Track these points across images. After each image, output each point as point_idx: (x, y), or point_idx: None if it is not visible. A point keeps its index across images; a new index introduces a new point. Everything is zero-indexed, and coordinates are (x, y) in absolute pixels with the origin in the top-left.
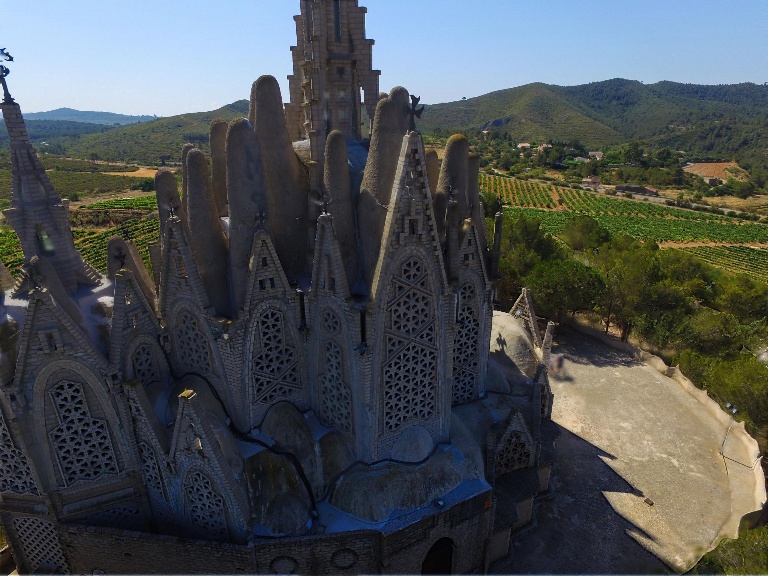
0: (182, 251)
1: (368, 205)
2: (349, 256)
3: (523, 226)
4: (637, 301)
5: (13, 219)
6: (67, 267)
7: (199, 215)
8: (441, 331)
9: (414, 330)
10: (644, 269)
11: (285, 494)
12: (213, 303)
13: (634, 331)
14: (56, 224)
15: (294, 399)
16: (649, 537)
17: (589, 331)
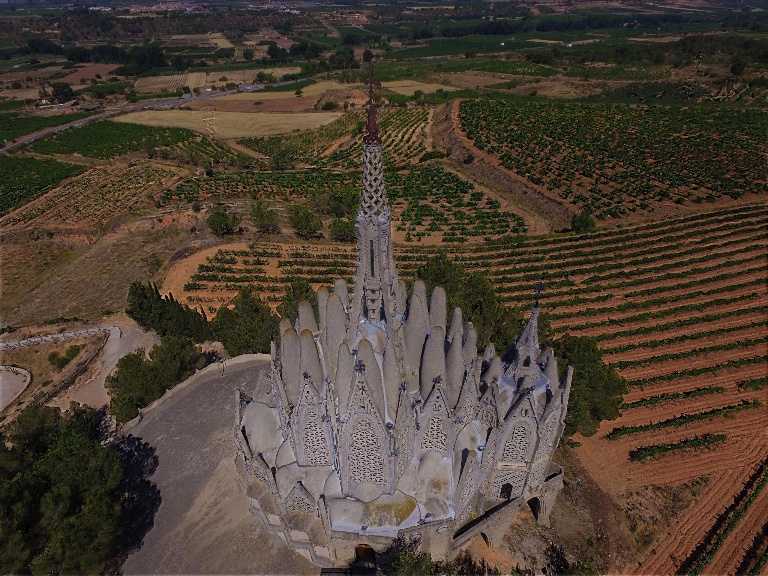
0: None
1: None
2: None
3: None
4: None
5: None
6: None
7: None
8: None
9: None
10: (1, 439)
11: None
12: None
13: None
14: None
15: None
16: None
17: None
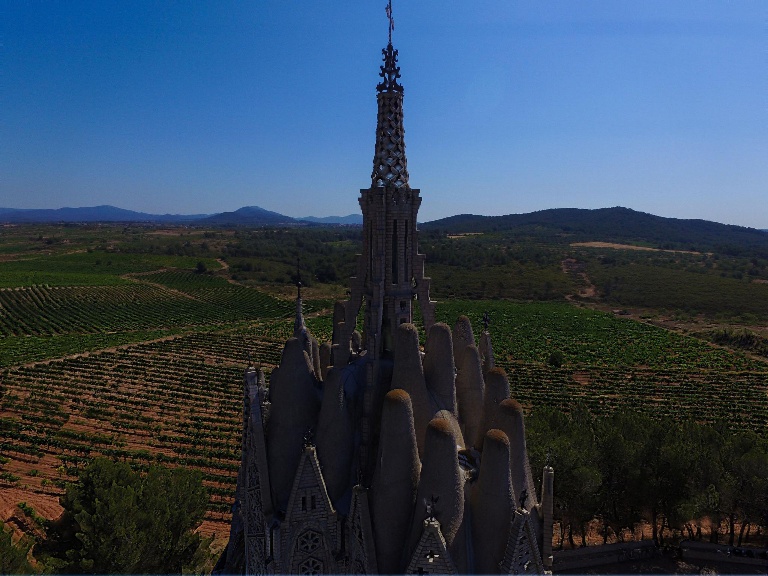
0: None
1: None
2: None
3: None
4: None
5: None
6: None
7: None
8: None
9: None
10: None
11: (232, 567)
12: None
13: None
14: None
15: None
16: None
17: None
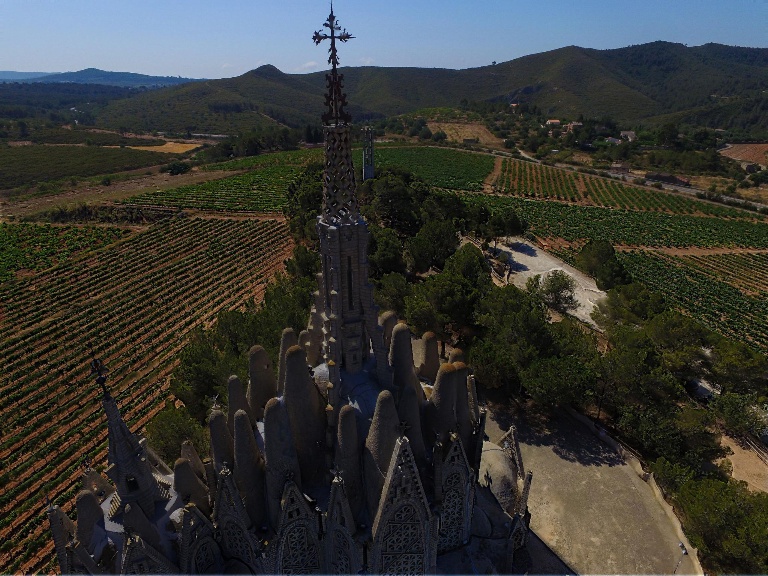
0: (232, 494)
1: (371, 463)
2: (356, 496)
3: (525, 318)
4: (627, 392)
5: (111, 474)
6: (147, 494)
7: (243, 457)
8: (427, 540)
9: (405, 546)
10: (635, 364)
11: None
12: (254, 520)
13: (622, 420)
14: (140, 469)
15: (314, 575)
16: None
17: (580, 418)
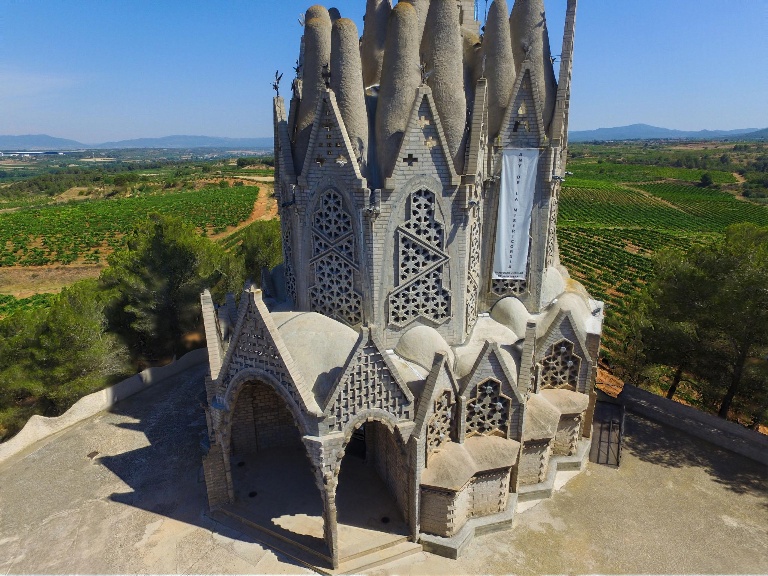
0: None
1: None
2: None
3: None
4: None
5: None
6: None
7: None
8: None
9: None
10: None
11: None
12: None
13: None
14: None
15: None
16: (117, 424)
17: None
